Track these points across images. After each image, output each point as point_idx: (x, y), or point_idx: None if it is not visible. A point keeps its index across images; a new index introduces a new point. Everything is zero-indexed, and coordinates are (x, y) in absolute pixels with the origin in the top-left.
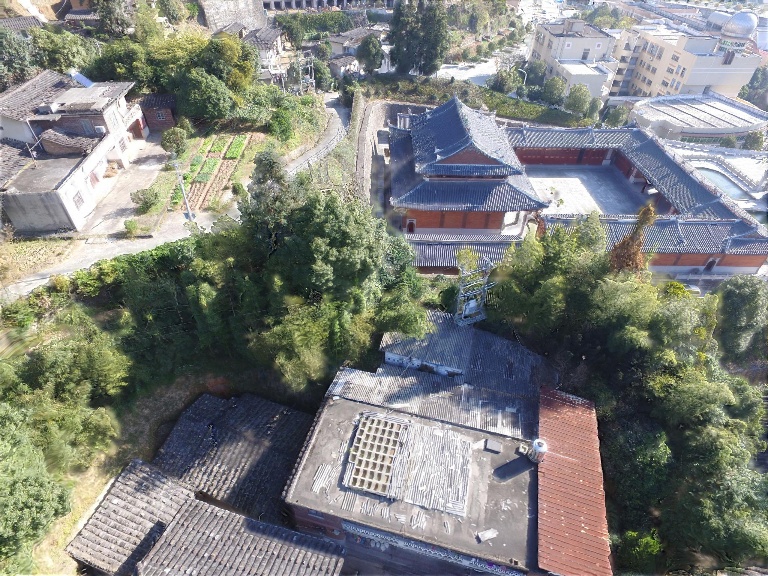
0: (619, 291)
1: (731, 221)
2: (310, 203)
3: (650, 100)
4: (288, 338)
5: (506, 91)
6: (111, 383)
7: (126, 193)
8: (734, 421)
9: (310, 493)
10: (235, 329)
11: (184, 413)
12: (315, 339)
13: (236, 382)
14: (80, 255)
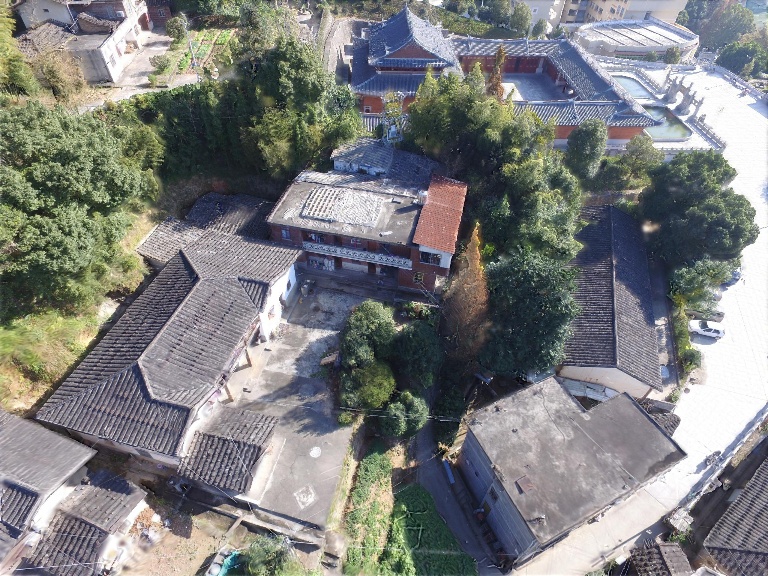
0: (483, 107)
1: (616, 102)
2: (276, 40)
3: (595, 24)
4: (266, 130)
5: (460, 11)
6: (154, 157)
7: (144, 63)
8: (554, 190)
9: (282, 219)
10: (231, 133)
11: (199, 198)
12: (283, 135)
13: (233, 185)
14: (119, 95)
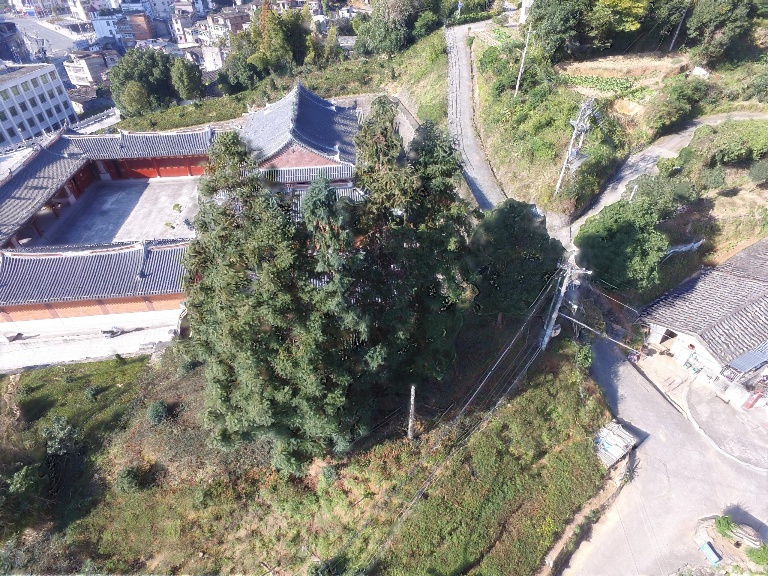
0: None
1: (71, 137)
2: None
3: None
4: None
5: None
6: None
7: None
8: None
9: None
10: None
11: None
12: None
13: None
14: None
